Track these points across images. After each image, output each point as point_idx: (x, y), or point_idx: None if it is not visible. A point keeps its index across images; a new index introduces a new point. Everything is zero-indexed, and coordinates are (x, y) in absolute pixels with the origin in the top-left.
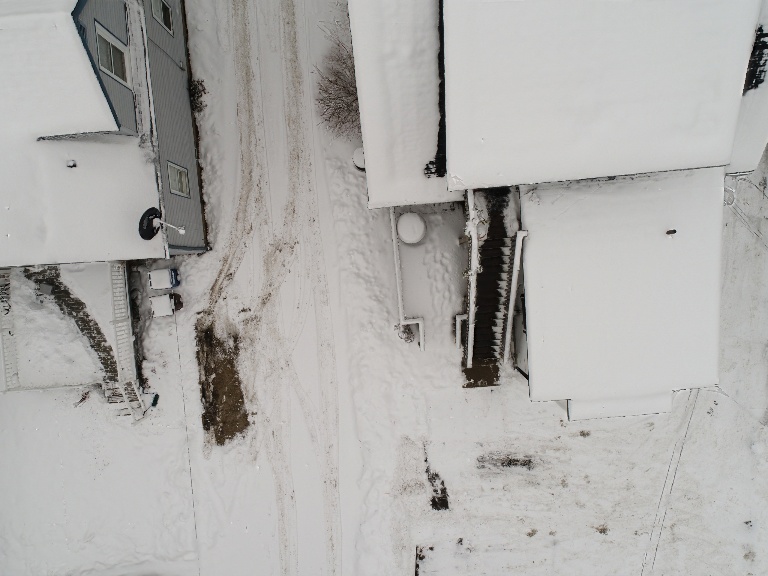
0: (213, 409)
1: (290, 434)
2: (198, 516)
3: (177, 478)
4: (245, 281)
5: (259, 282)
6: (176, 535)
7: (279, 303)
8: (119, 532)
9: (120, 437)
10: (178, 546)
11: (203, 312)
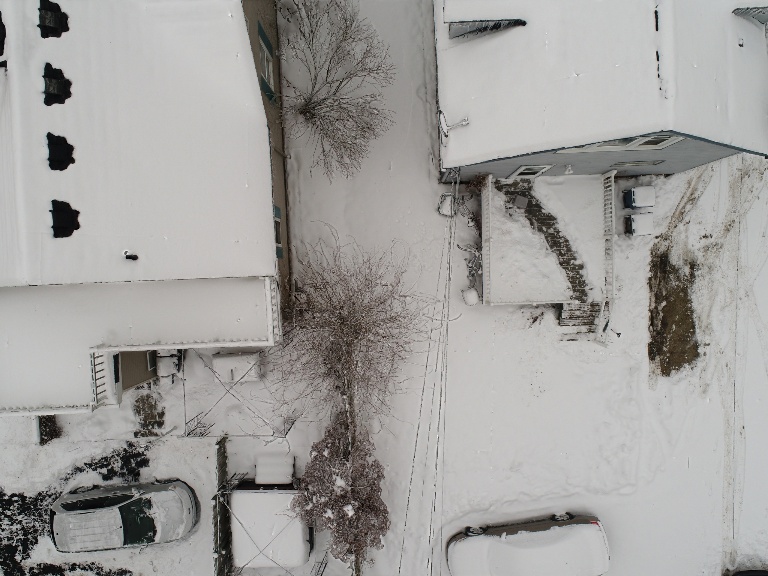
0: (660, 338)
1: (745, 367)
2: (641, 448)
3: (623, 408)
4: (710, 206)
5: (724, 208)
6: (618, 467)
7: (744, 230)
8: (550, 462)
9: (562, 363)
10: (620, 478)
11: (660, 237)
